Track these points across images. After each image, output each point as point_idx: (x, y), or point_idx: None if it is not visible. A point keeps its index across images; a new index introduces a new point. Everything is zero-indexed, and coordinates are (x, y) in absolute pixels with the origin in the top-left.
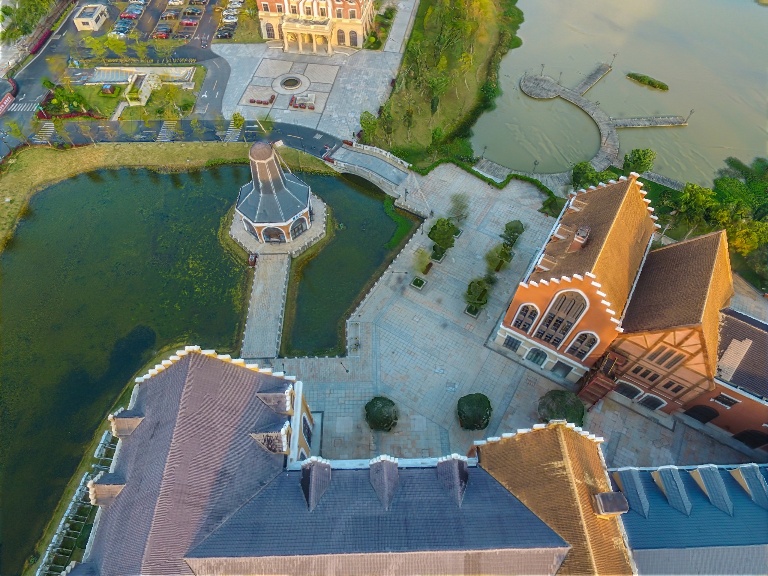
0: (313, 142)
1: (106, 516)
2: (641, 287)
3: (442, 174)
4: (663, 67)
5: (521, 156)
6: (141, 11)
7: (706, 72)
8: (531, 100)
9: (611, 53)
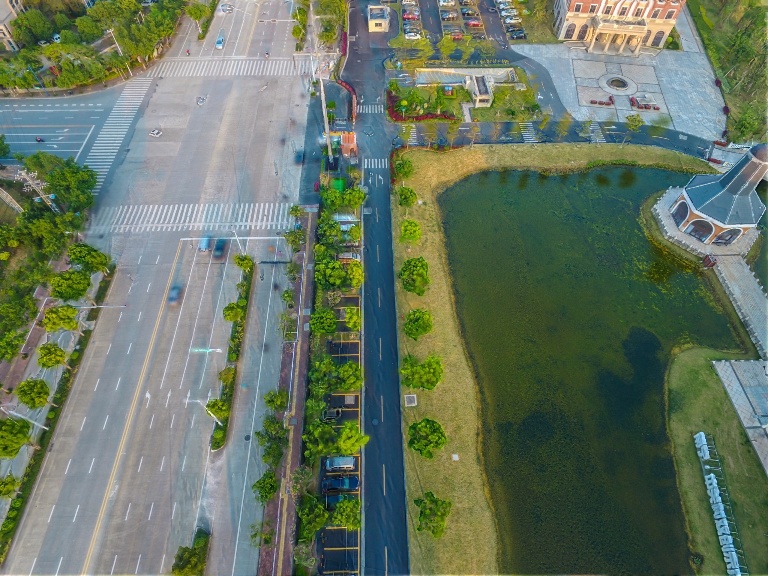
0: (683, 143)
1: None
2: None
3: None
4: None
5: None
6: (418, 12)
7: None
8: None
9: None
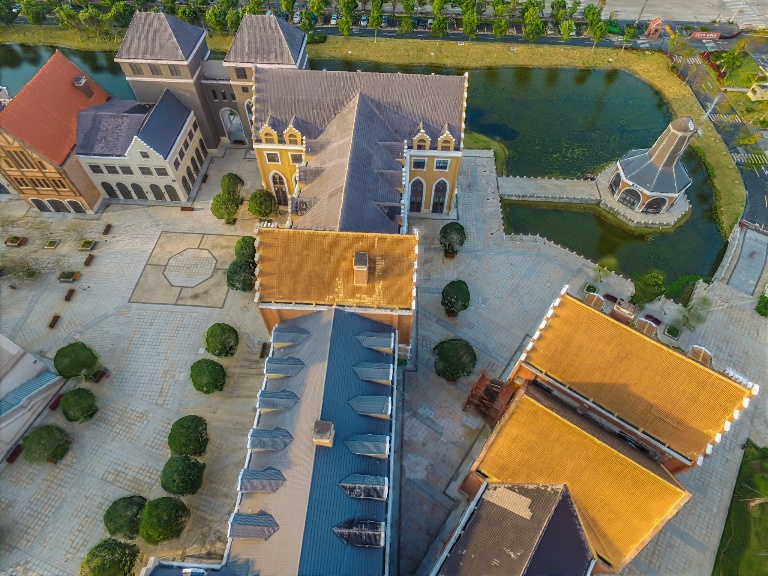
0: (765, 215)
1: None
2: None
3: None
4: None
5: None
6: None
7: None
8: None
9: None
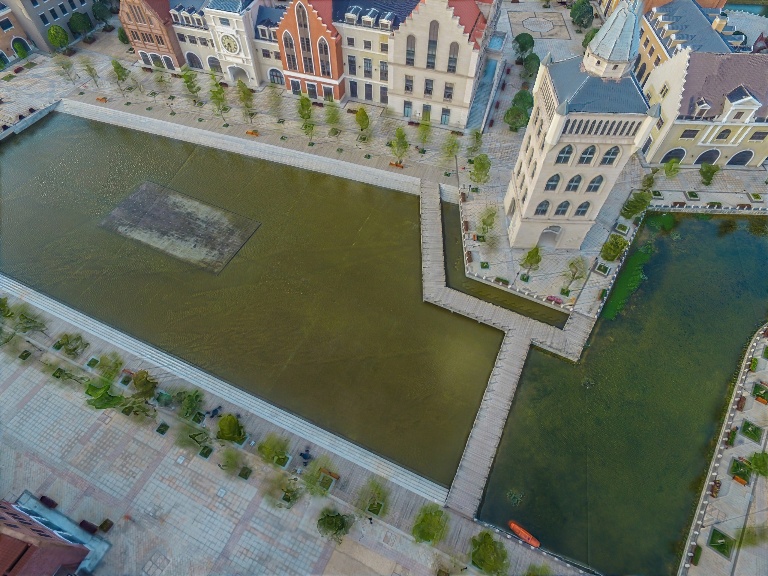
0: None
1: None
2: None
3: None
4: None
5: None
6: None
7: None
8: None
9: None
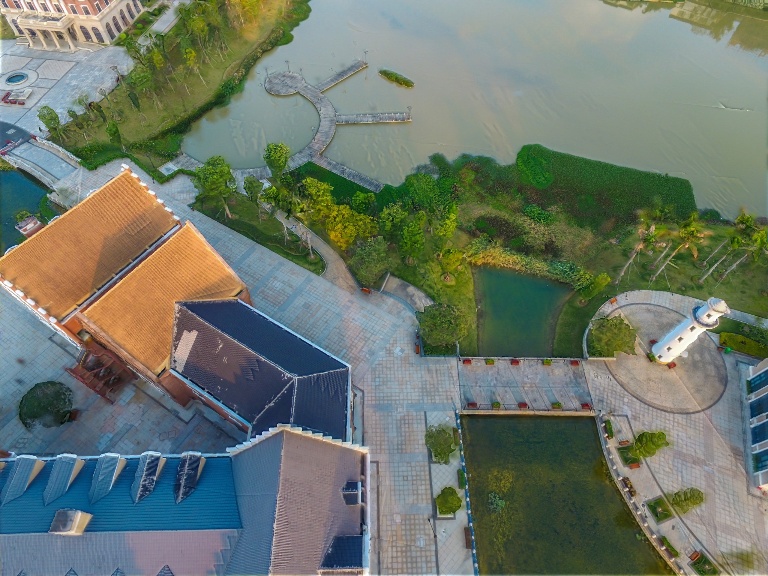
0: (2, 137)
1: None
2: None
3: (112, 169)
4: (419, 64)
5: (228, 152)
6: None
7: (460, 69)
8: (272, 96)
9: (364, 50)
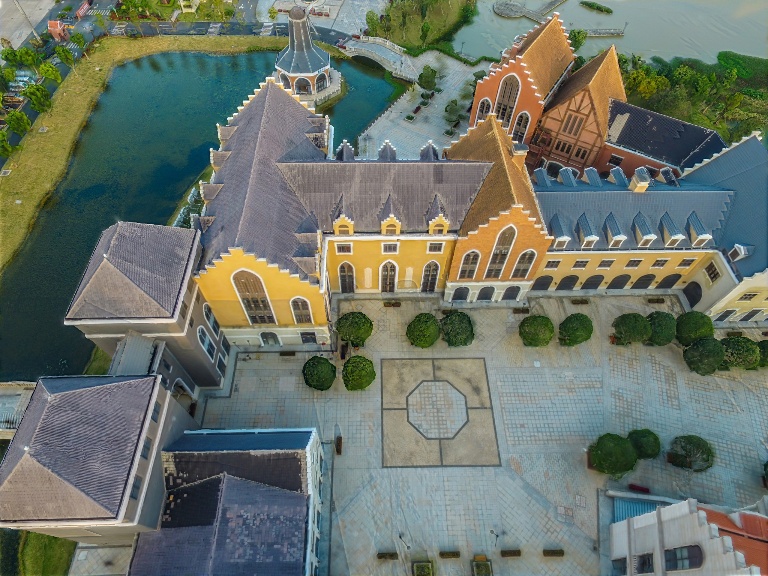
0: (329, 36)
1: (220, 170)
2: (561, 91)
3: (429, 57)
4: None
5: (492, 54)
6: None
7: (644, 1)
8: (502, 19)
9: None
